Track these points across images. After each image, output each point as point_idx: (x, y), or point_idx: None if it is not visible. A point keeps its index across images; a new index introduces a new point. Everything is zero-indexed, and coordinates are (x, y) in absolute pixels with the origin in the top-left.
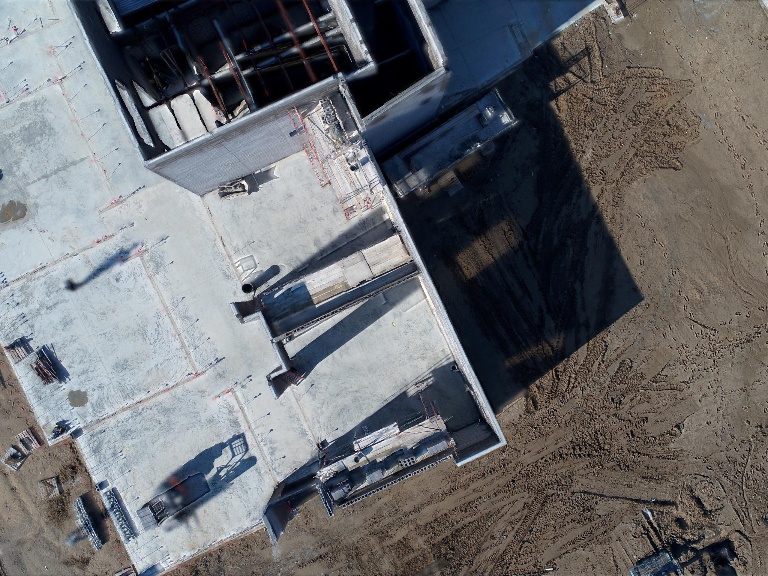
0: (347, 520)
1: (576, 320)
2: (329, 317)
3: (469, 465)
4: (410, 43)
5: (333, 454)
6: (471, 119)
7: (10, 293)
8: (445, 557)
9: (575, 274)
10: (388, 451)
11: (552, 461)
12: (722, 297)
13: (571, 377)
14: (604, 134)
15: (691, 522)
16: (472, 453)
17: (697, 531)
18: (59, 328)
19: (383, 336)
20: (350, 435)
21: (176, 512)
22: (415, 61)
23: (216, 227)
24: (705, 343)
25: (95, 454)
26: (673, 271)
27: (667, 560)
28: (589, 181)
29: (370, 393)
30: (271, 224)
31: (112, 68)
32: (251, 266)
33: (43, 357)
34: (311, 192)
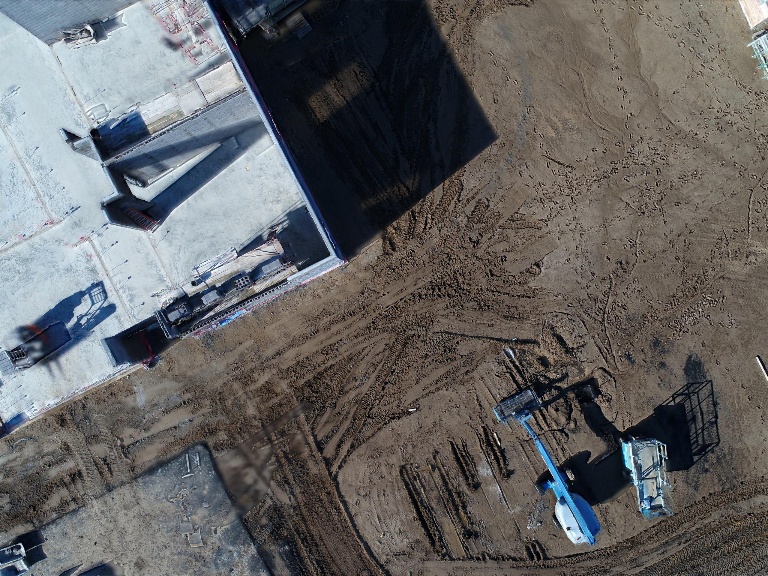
0: (209, 366)
1: (431, 160)
2: (182, 163)
3: (329, 308)
4: None
5: None
6: None
7: None
8: (308, 400)
9: (428, 114)
10: (227, 276)
11: (412, 302)
12: (578, 134)
13: (428, 218)
14: None
15: (553, 360)
16: None
17: (560, 368)
18: None
19: (237, 180)
20: None
21: (38, 361)
22: None
23: (66, 76)
24: (562, 180)
25: None
26: (527, 109)
27: (530, 397)
28: (439, 20)
29: (226, 238)
30: (121, 72)
31: None
32: (103, 115)
33: None
34: (159, 38)
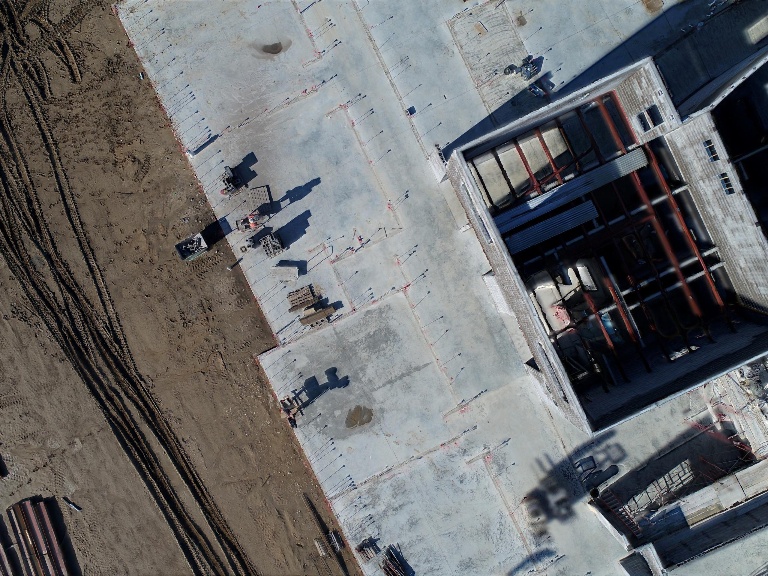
0: None
1: None
2: None
3: None
4: None
5: None
6: None
7: (357, 495)
8: None
9: None
10: None
11: None
12: None
13: None
14: None
15: None
16: None
17: None
18: (405, 528)
19: None
20: None
21: None
22: None
23: (556, 429)
24: None
25: None
26: None
27: None
28: None
29: None
30: None
31: None
32: (590, 466)
33: (392, 558)
34: None
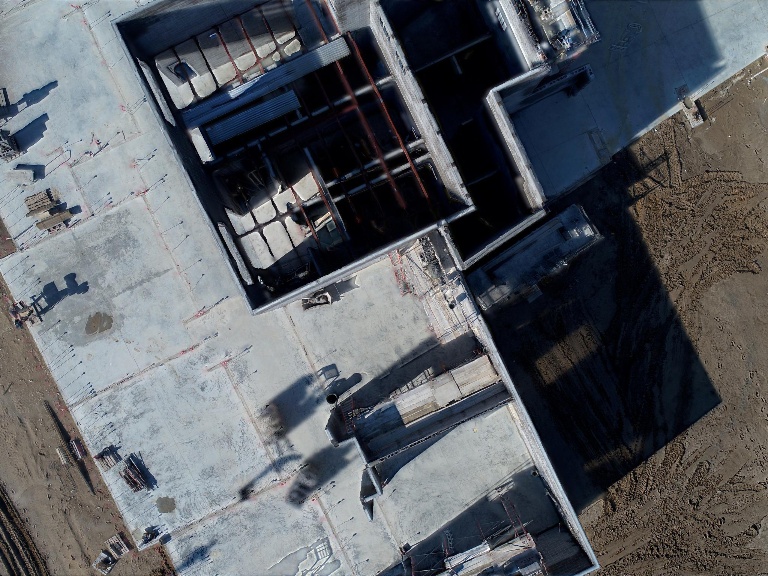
0: None
1: (654, 423)
2: None
3: None
4: (497, 164)
5: (419, 563)
6: (554, 232)
7: (98, 403)
8: None
9: (653, 378)
10: (479, 568)
11: (630, 561)
12: None
13: (649, 479)
14: (683, 238)
15: None
16: (564, 575)
17: None
18: (146, 437)
19: (464, 442)
20: (432, 539)
21: None
22: (502, 181)
23: (299, 336)
24: None
25: (183, 559)
26: (751, 373)
27: None
28: (667, 286)
29: (451, 498)
30: (353, 333)
31: (213, 209)
32: (333, 374)
33: (132, 466)
34: (392, 301)
